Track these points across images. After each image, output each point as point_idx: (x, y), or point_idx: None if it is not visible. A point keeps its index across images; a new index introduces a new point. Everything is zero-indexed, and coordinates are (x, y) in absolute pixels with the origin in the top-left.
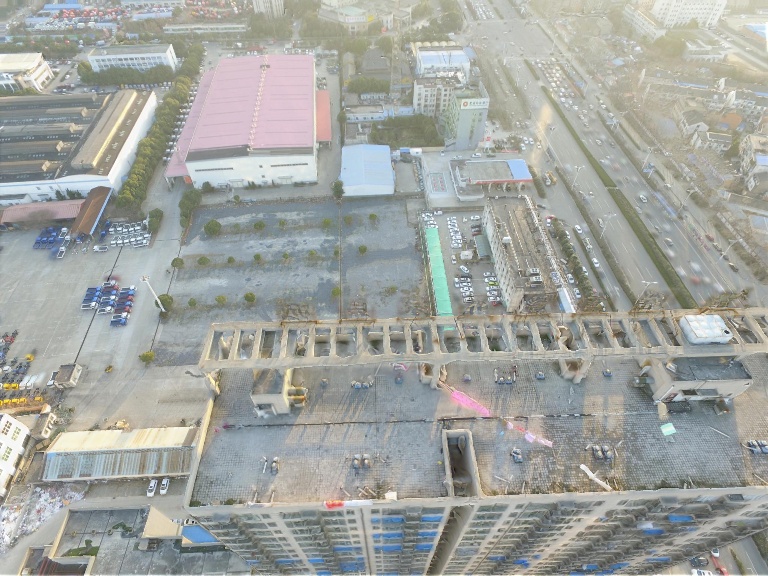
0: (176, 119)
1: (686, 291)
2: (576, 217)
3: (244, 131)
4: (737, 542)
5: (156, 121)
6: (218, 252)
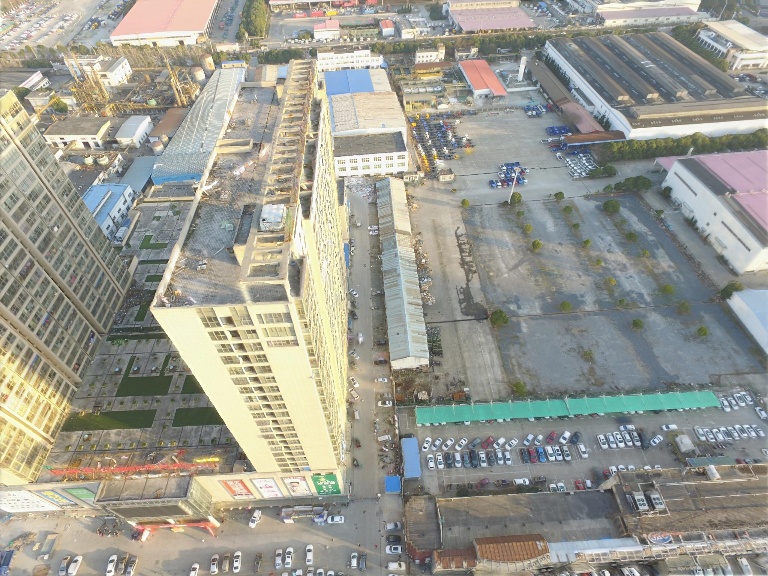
0: (762, 148)
1: None
2: None
3: (761, 185)
4: None
5: (739, 134)
6: (586, 219)
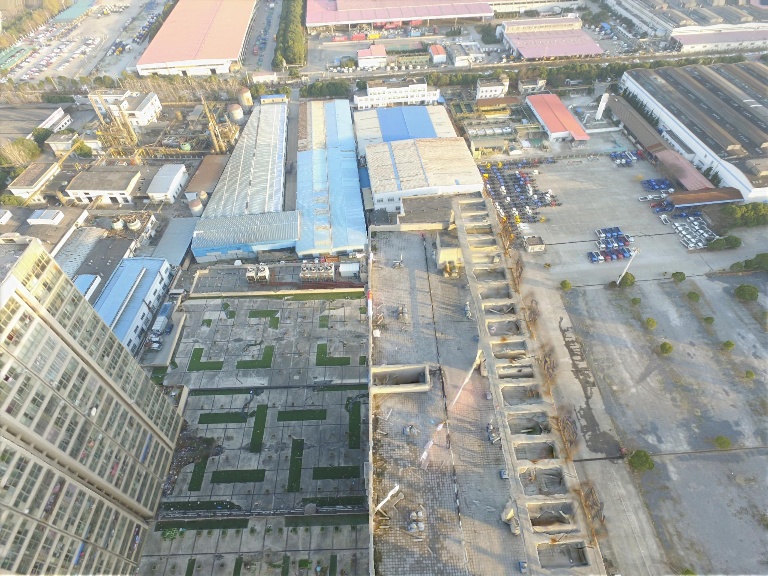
0: None
1: None
2: None
3: None
4: None
5: None
6: (716, 308)
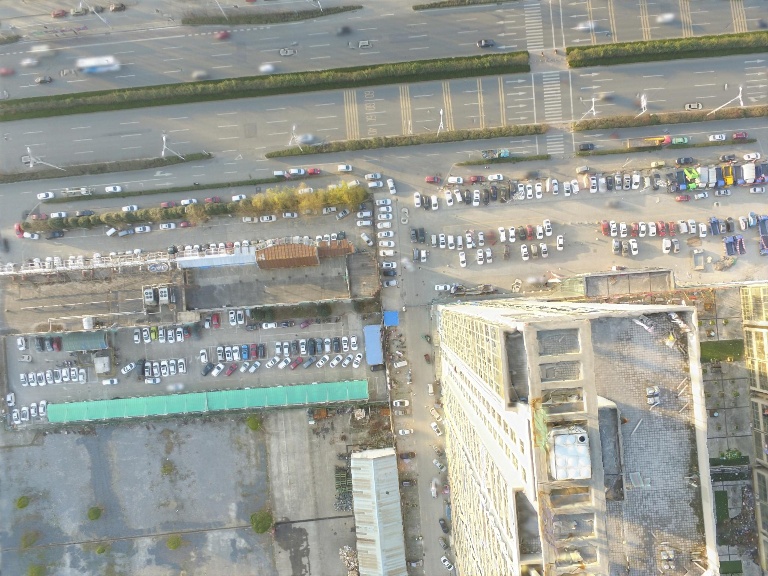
0: None
1: (164, 90)
2: (18, 192)
3: None
4: (450, 157)
5: None
6: None
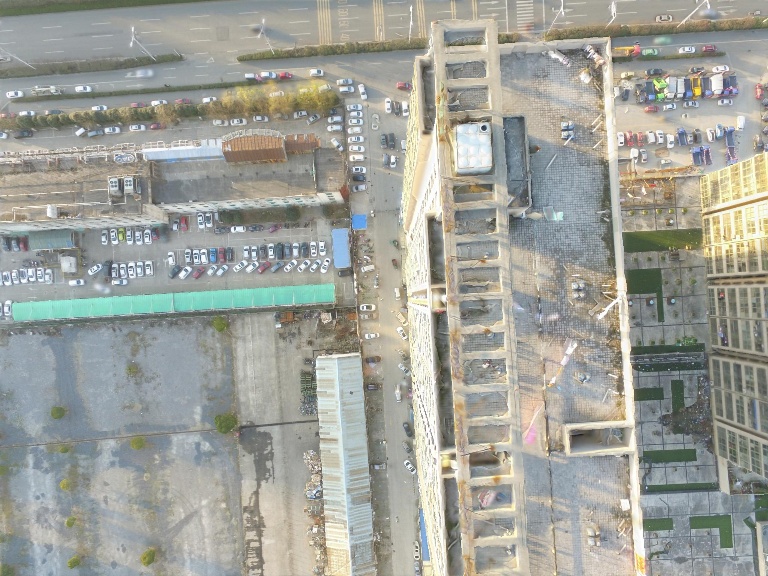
0: None
1: None
2: None
3: None
4: None
5: None
6: None
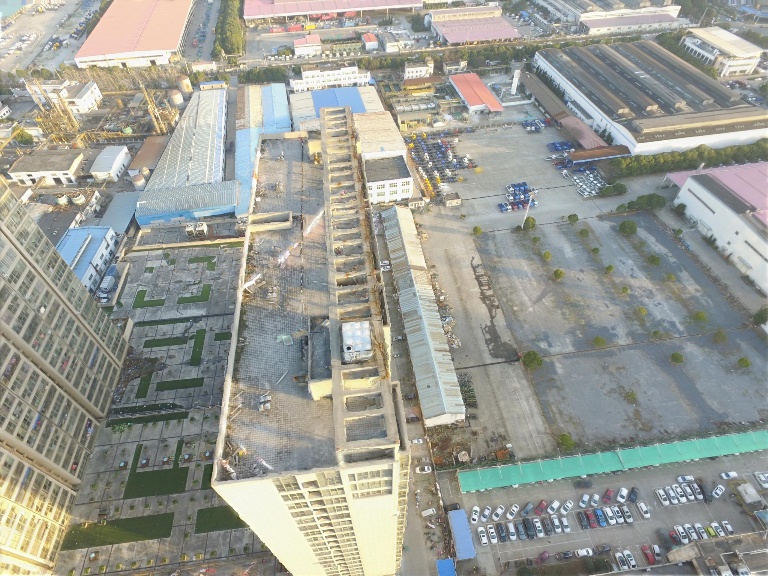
0: (765, 158)
1: None
2: None
3: None
4: None
5: (743, 145)
6: (603, 242)
